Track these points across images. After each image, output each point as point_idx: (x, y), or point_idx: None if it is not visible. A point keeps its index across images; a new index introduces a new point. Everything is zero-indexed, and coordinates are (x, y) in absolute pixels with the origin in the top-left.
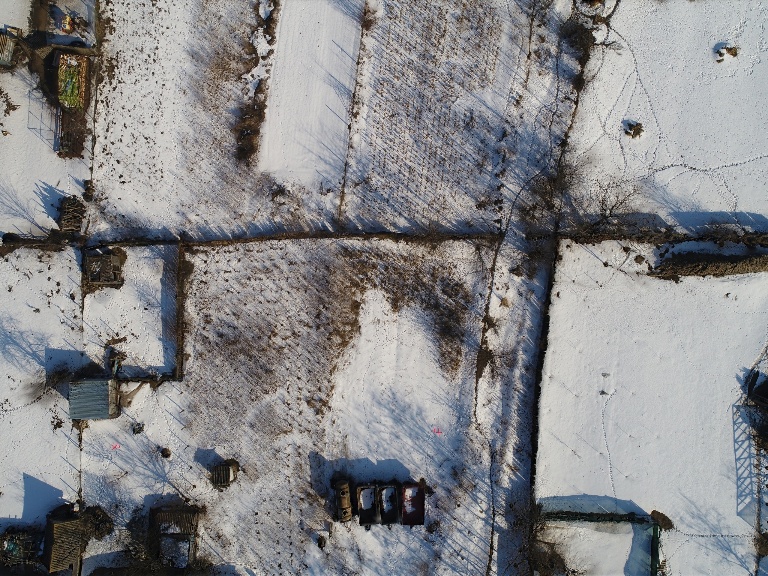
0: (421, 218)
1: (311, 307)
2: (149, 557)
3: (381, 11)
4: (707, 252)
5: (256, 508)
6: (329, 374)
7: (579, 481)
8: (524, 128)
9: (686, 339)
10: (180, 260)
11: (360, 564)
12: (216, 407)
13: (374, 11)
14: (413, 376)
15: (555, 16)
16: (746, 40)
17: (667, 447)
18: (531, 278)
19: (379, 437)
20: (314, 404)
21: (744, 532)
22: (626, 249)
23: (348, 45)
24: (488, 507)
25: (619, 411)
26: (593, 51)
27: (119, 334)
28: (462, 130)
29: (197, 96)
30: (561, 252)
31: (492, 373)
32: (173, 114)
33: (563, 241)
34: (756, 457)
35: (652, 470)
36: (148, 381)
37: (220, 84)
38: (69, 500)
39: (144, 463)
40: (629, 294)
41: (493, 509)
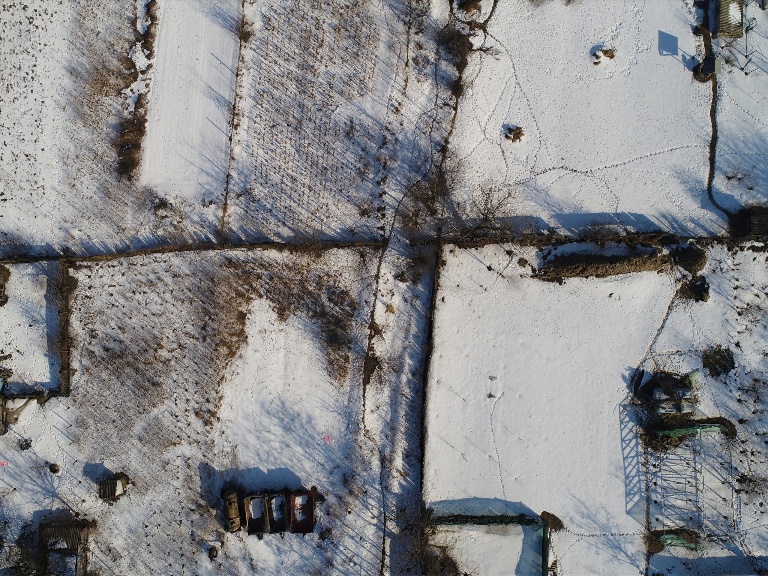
0: (305, 227)
1: (197, 319)
2: None
3: (259, 23)
4: (589, 253)
5: (146, 521)
6: (217, 385)
7: (469, 484)
8: (404, 135)
9: (571, 340)
10: (63, 276)
11: (253, 573)
12: (104, 421)
13: (252, 23)
14: (302, 384)
15: (432, 23)
16: (622, 42)
17: (555, 448)
18: (416, 284)
19: (269, 446)
20: (202, 415)
21: (633, 530)
22: (509, 252)
23: (227, 57)
24: (379, 513)
25: (507, 413)
26: (471, 57)
27: (4, 351)
28: (343, 139)
29: (77, 112)
30: (444, 257)
31: (380, 379)
32: (53, 131)
33: (446, 246)
34: (643, 455)
35: (541, 471)
36: (35, 397)
37: (100, 100)
38: None
39: (33, 479)
40: (514, 297)
41: (384, 515)
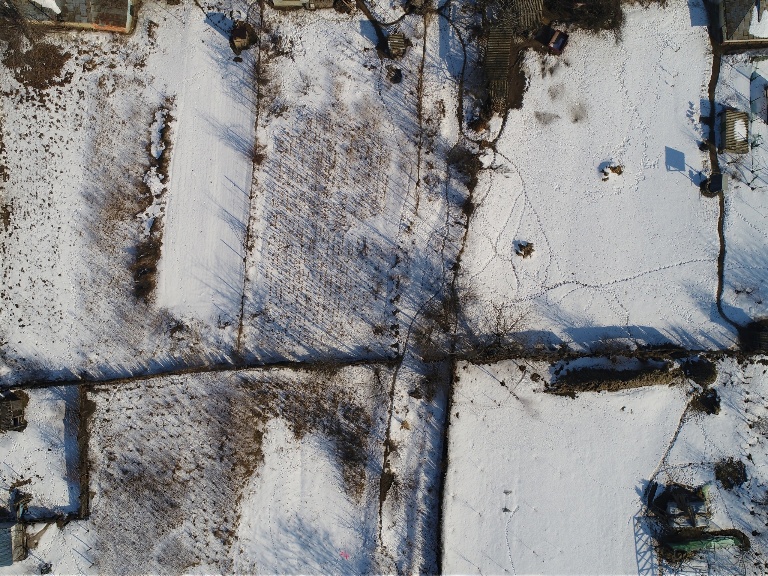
0: (320, 346)
1: (214, 439)
2: None
3: (271, 145)
4: (601, 367)
5: None
6: (235, 504)
7: None
8: (416, 253)
9: (585, 454)
10: (82, 400)
11: None
12: (123, 543)
13: (264, 146)
14: (318, 501)
15: (442, 143)
16: (630, 158)
17: (571, 561)
18: (430, 400)
19: (287, 564)
20: (221, 535)
21: None
22: (521, 368)
23: (240, 180)
24: None
25: (522, 527)
26: (481, 175)
27: (24, 476)
28: (356, 258)
29: (93, 237)
30: (458, 374)
31: (396, 495)
32: (70, 256)
33: (459, 363)
34: (658, 567)
35: None
36: (55, 521)
37: (116, 224)
38: None
39: None
40: (527, 411)
41: None
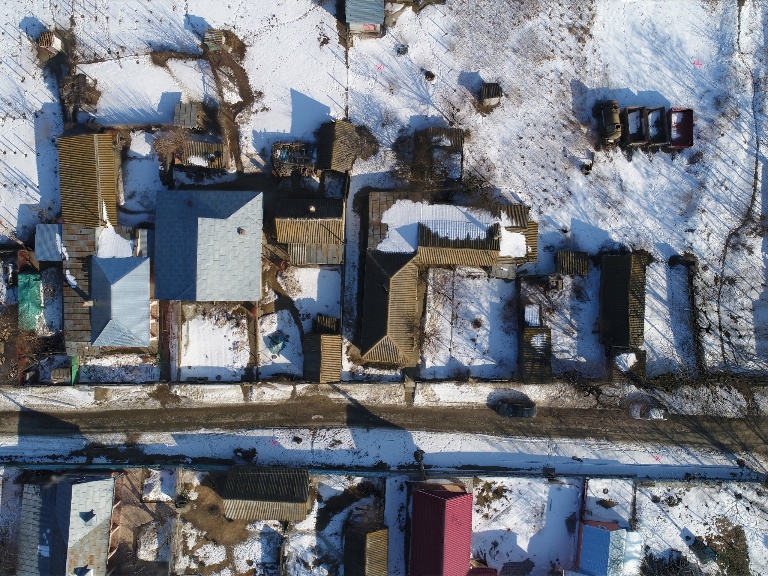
0: None
1: None
2: (414, 180)
3: None
4: None
5: (520, 132)
6: (590, 2)
7: None
8: None
9: None
10: None
11: (623, 194)
12: (479, 31)
13: None
14: (673, 7)
15: None
16: None
17: None
18: None
19: (639, 68)
20: (576, 31)
21: None
22: None
23: None
24: (751, 138)
25: None
26: None
27: None
28: None
29: None
30: None
31: (753, 3)
32: None
33: None
34: None
35: None
36: (411, 4)
37: None
38: (336, 117)
39: (408, 85)
40: None
41: (757, 139)
